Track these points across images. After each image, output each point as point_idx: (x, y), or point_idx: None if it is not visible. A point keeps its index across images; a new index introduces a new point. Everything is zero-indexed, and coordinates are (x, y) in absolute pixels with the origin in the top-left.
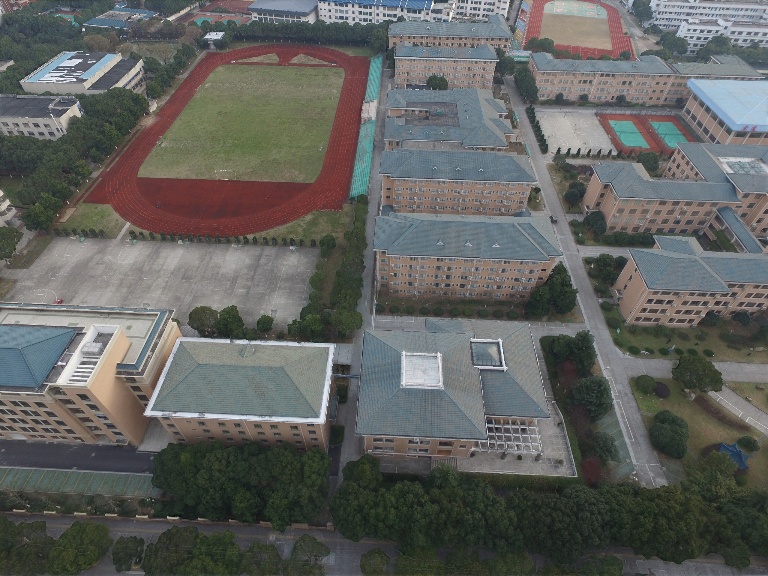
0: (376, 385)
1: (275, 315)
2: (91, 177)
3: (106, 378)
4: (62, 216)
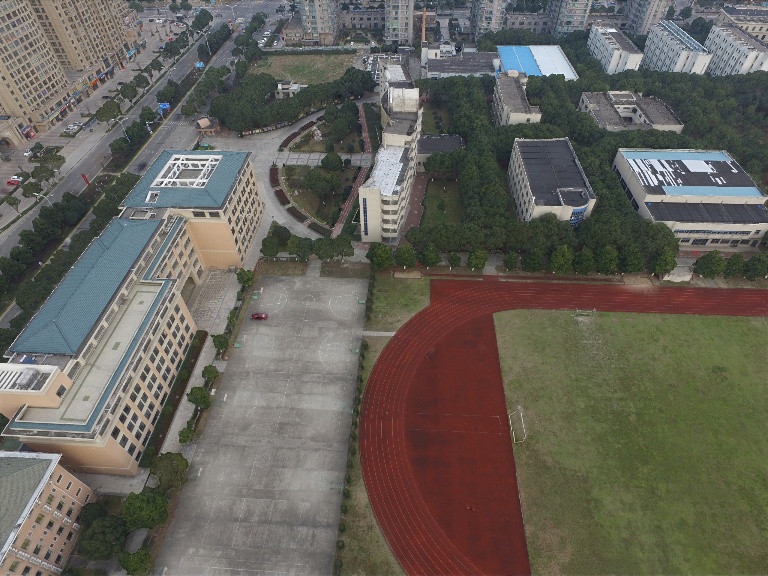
0: None
1: (158, 575)
2: (483, 270)
3: (5, 401)
4: (405, 271)
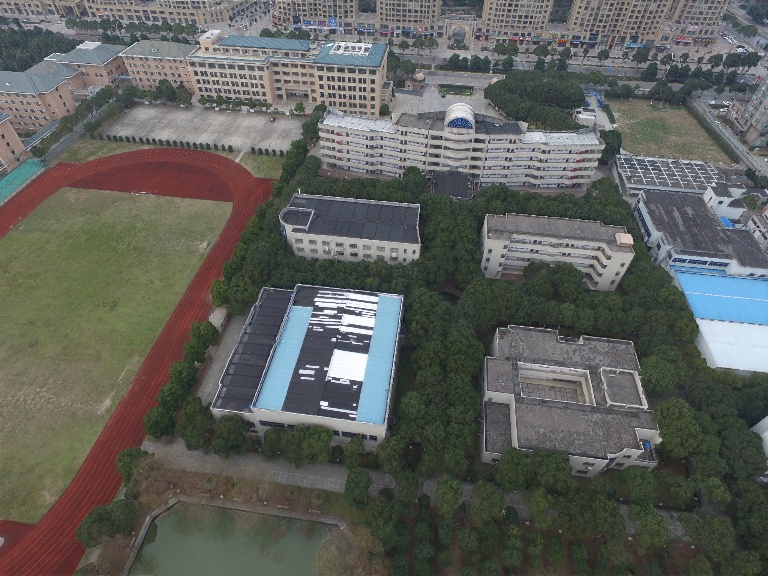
0: (111, 49)
1: None
2: None
3: None
4: None
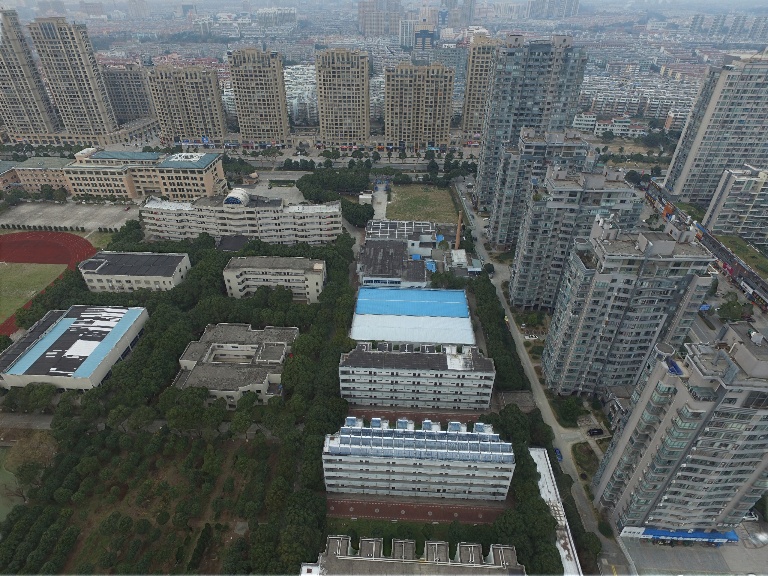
0: None
1: None
2: None
3: None
4: None
